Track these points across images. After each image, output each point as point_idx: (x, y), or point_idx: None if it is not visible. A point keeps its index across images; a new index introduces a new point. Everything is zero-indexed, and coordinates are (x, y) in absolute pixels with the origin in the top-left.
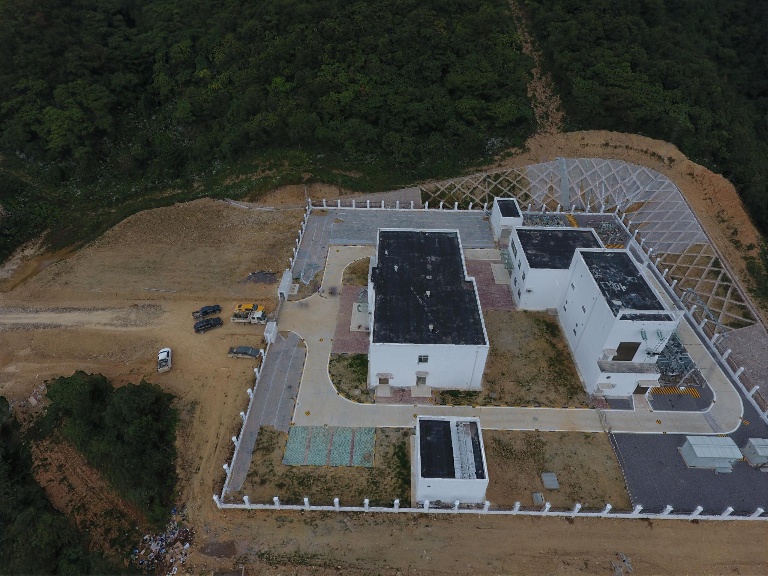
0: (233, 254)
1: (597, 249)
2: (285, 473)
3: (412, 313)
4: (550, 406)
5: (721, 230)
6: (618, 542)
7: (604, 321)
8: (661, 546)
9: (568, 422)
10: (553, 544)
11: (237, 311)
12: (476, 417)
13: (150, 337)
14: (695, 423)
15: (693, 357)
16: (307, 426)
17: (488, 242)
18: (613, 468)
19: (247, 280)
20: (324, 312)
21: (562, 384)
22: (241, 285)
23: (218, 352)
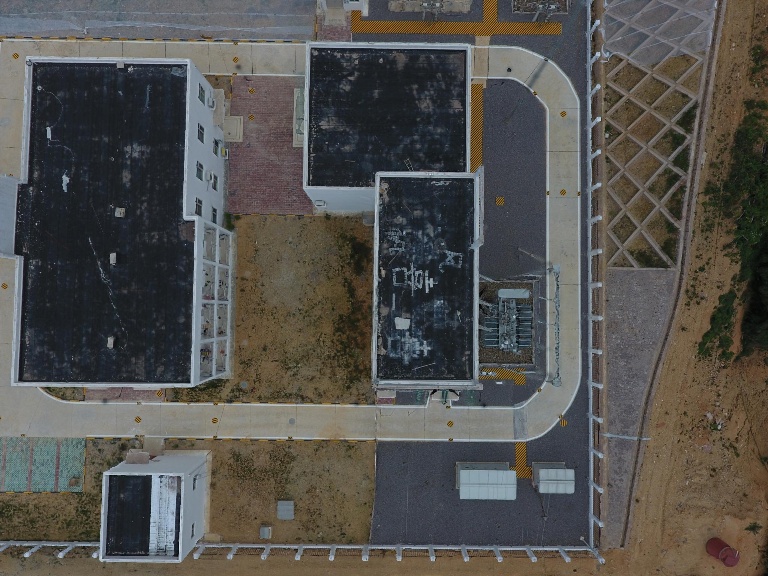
0: None
1: (417, 175)
2: None
3: (86, 305)
4: (316, 402)
5: (755, 12)
6: (342, 571)
7: None
8: (386, 575)
9: (333, 426)
10: (273, 574)
11: None
12: (180, 474)
13: None
14: (496, 426)
15: (552, 311)
16: None
17: (302, 20)
18: (366, 491)
19: None
20: None
21: (343, 364)
22: None
23: None
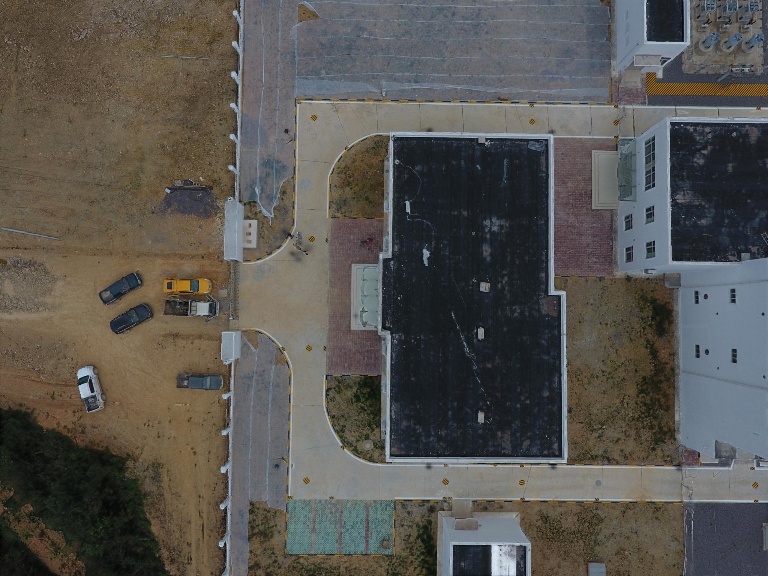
0: (123, 129)
1: None
2: (291, 565)
3: (451, 379)
4: (622, 464)
5: None
6: None
7: (764, 434)
8: None
9: (639, 488)
10: None
11: (168, 299)
12: (527, 544)
13: (53, 336)
14: None
15: None
16: (308, 500)
17: (598, 82)
18: (675, 553)
19: (166, 208)
20: (306, 287)
21: (648, 426)
22: (159, 221)
23: (162, 374)
